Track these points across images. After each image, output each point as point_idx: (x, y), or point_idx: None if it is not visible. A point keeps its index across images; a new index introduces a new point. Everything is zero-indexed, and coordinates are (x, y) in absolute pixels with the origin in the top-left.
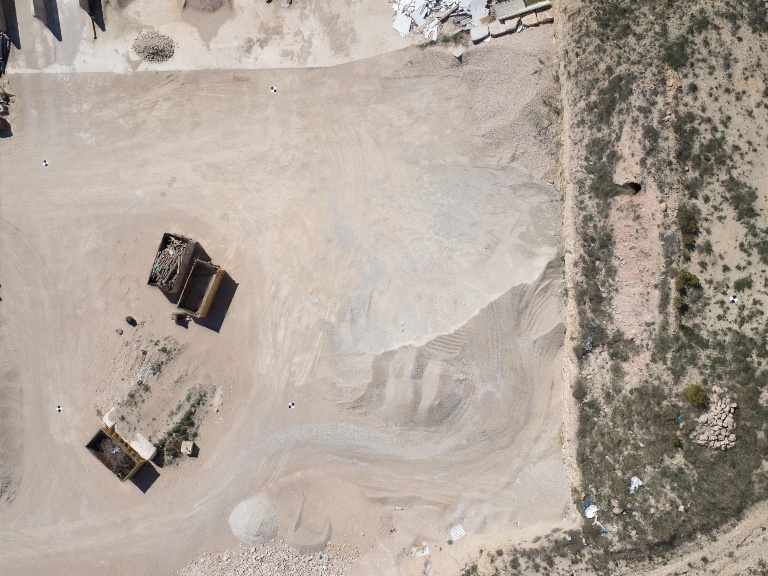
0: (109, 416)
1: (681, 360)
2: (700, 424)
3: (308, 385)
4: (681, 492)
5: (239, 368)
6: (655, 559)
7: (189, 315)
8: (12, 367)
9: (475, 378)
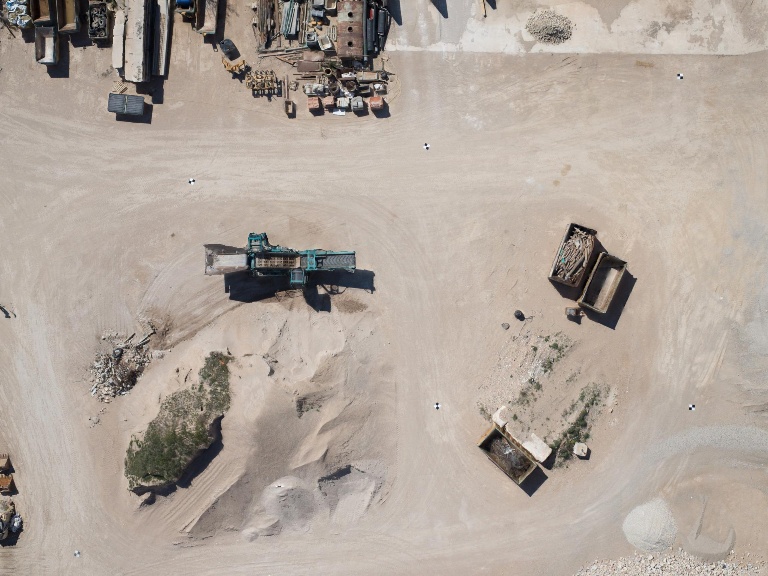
0: (501, 415)
1: None
2: None
3: (710, 386)
4: None
5: (636, 367)
6: None
7: (582, 310)
8: (387, 361)
9: None
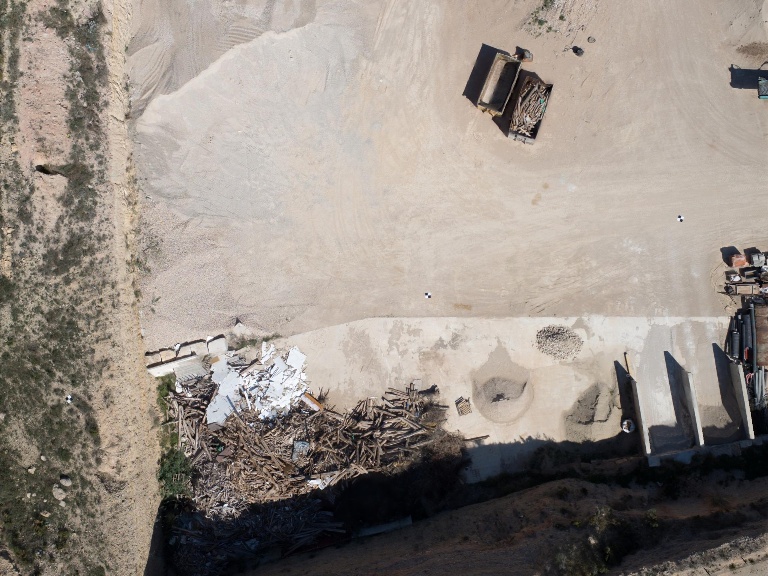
0: None
1: None
2: None
3: None
4: None
5: (461, 8)
6: None
7: None
8: None
9: (215, 4)
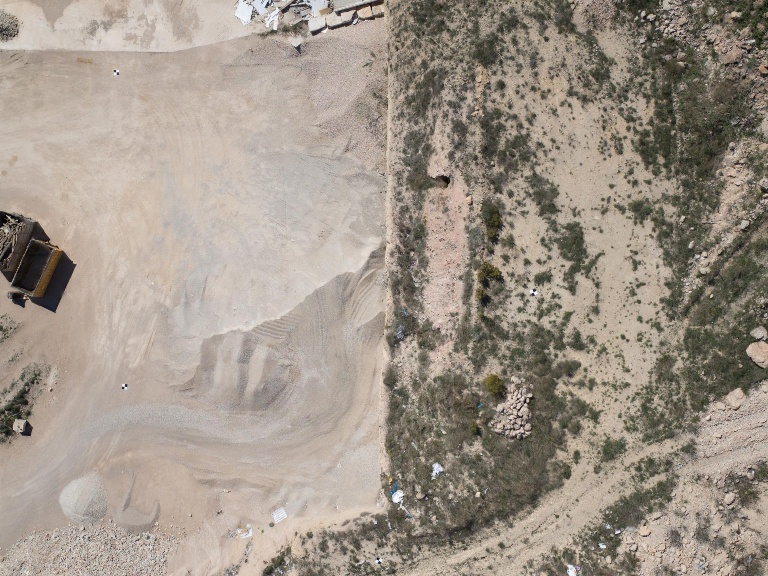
0: None
1: (482, 350)
2: (498, 413)
3: (142, 367)
4: (478, 479)
5: (74, 348)
6: (455, 544)
7: (26, 294)
8: None
9: (300, 364)
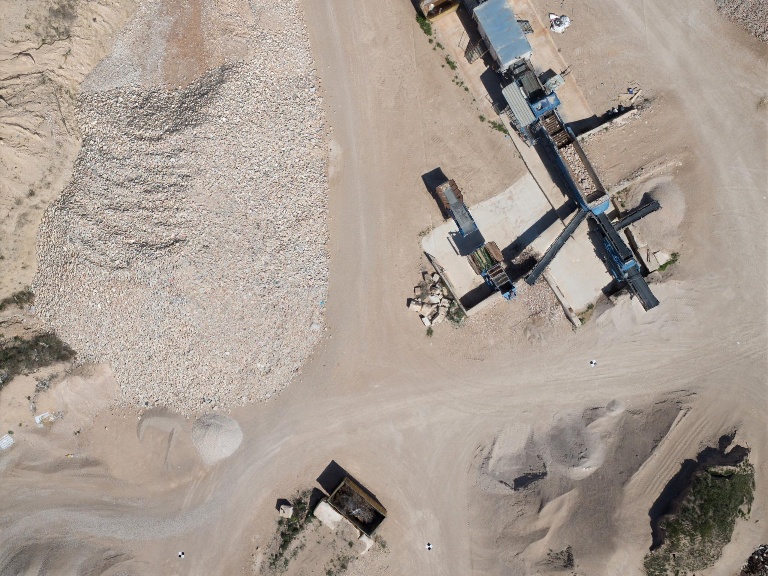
0: (365, 547)
1: None
2: None
3: None
4: None
5: None
6: None
7: None
8: None
9: None
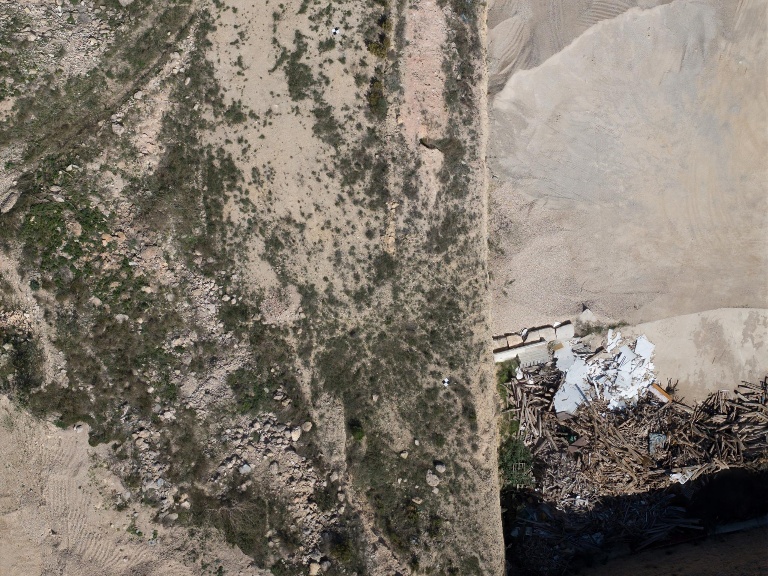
0: None
1: None
2: None
3: None
4: None
5: None
6: None
7: None
8: None
9: None
